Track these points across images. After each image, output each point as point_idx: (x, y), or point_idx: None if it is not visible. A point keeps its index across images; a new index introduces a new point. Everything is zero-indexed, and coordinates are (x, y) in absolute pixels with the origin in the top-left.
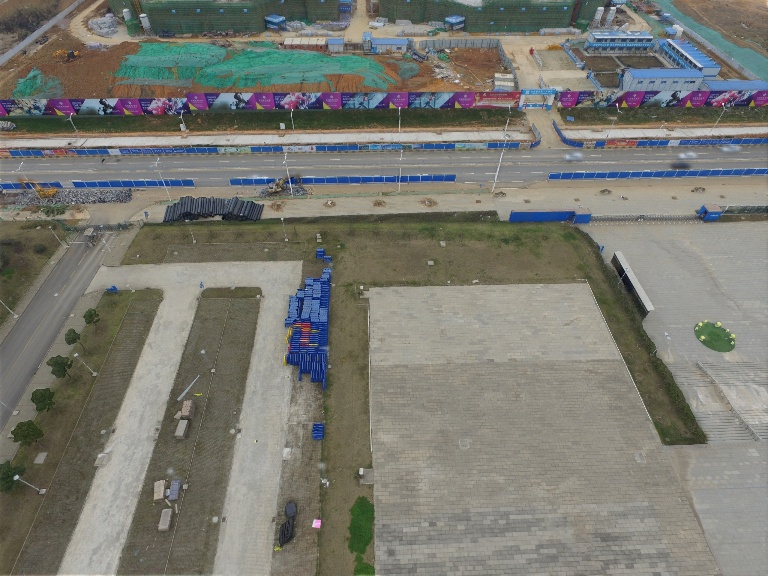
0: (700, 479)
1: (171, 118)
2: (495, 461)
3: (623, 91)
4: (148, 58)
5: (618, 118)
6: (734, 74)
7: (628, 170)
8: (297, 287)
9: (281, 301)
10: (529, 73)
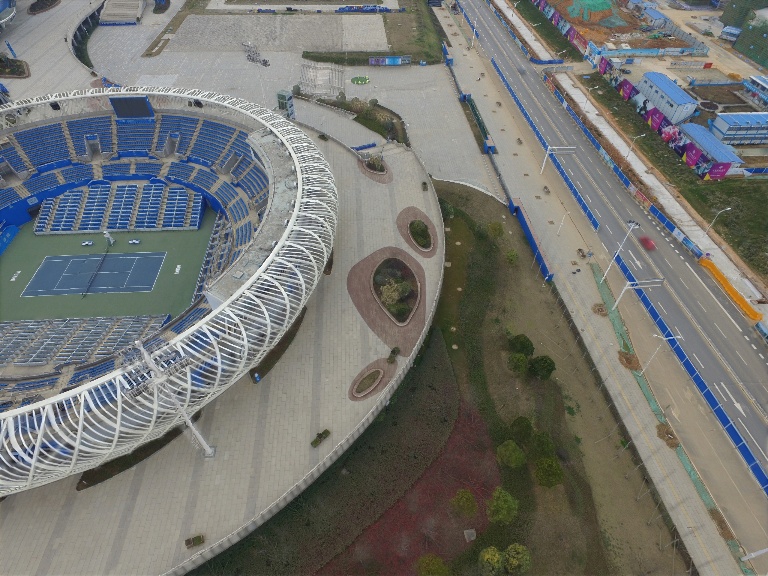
0: (289, 54)
1: None
2: None
3: None
4: None
5: (601, 94)
6: None
7: (517, 87)
8: None
9: None
10: (655, 63)
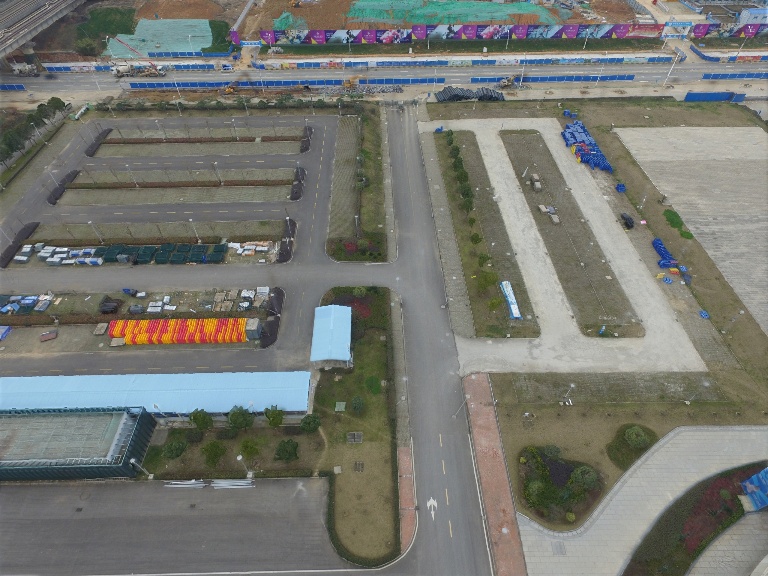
0: None
1: (397, 45)
2: (739, 197)
3: (743, 23)
4: (371, 3)
5: (739, 45)
6: None
7: None
8: (561, 130)
9: (555, 136)
10: (659, 16)
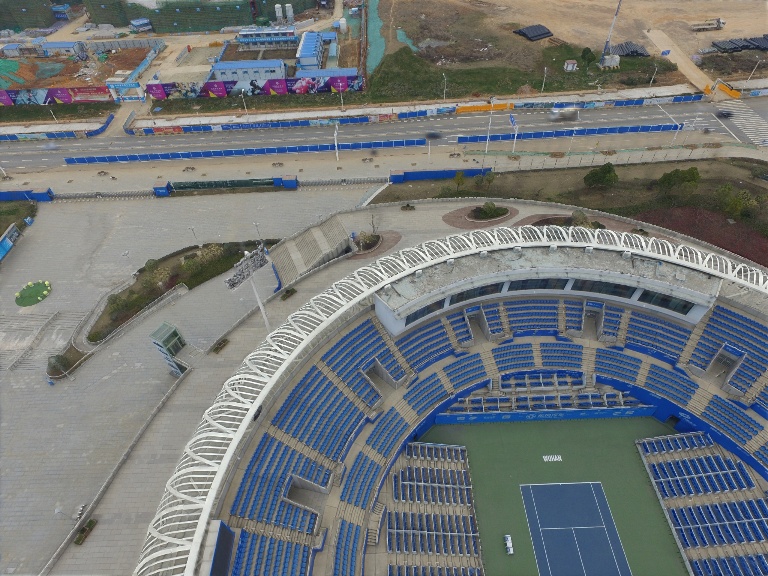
0: None
1: None
2: None
3: (202, 82)
4: None
5: (201, 107)
6: (354, 63)
7: None
8: None
9: None
10: (163, 69)
